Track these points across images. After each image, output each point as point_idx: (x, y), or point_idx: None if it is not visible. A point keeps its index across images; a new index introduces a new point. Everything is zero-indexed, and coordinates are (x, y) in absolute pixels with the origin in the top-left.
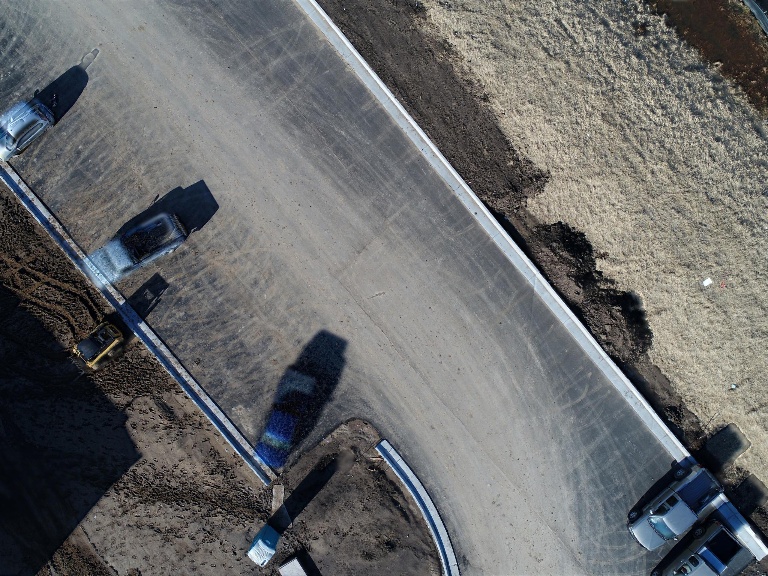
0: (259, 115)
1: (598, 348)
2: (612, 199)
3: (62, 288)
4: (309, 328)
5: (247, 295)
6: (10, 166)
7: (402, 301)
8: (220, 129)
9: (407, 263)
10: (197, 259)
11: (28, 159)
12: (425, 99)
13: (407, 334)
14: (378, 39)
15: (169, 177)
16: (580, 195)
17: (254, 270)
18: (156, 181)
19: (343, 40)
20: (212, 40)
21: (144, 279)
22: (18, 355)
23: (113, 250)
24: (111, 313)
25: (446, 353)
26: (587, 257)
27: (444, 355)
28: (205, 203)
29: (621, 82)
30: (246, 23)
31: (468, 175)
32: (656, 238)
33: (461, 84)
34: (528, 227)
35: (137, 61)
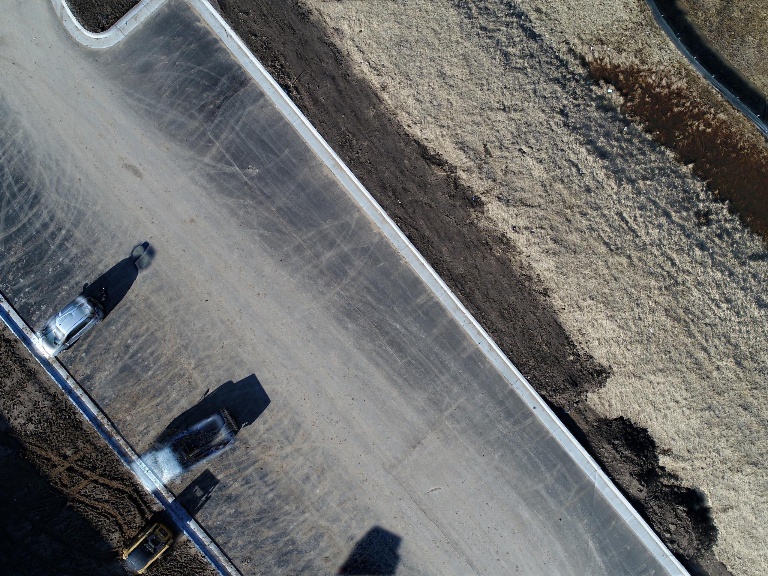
0: (312, 308)
1: (662, 546)
2: (676, 396)
3: (110, 485)
4: (362, 524)
5: (299, 491)
6: (58, 361)
7: (458, 497)
8: (272, 322)
9: (463, 458)
10: (248, 454)
11: (76, 354)
12: (482, 293)
13: (463, 530)
14: (434, 232)
15: (220, 371)
16: (643, 391)
17: (306, 465)
18: (206, 375)
19: (398, 233)
20: (264, 232)
21: (194, 476)
22: (65, 555)
23: (162, 446)
24: (160, 511)
25: (504, 550)
26: (650, 454)
27: (502, 552)
28: (256, 397)
29: (685, 276)
30: (299, 215)
31: (527, 369)
32: (722, 436)
33: (520, 278)
34: (588, 421)
35: (188, 254)
